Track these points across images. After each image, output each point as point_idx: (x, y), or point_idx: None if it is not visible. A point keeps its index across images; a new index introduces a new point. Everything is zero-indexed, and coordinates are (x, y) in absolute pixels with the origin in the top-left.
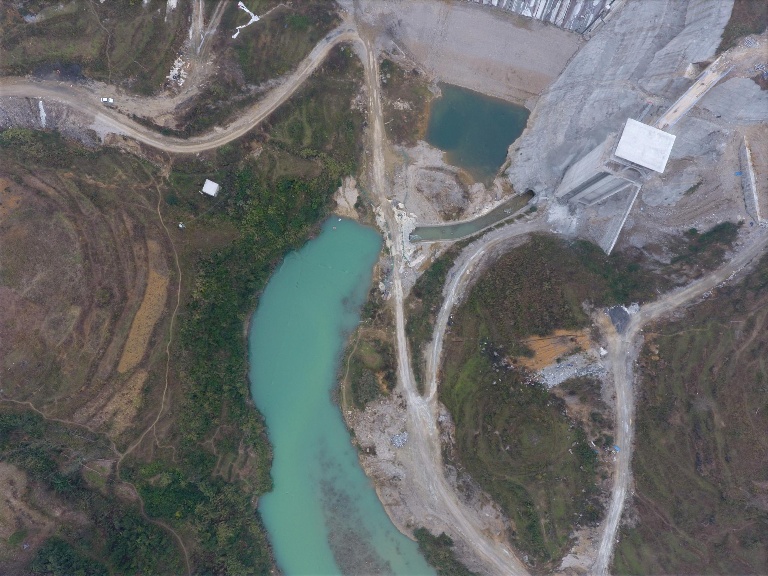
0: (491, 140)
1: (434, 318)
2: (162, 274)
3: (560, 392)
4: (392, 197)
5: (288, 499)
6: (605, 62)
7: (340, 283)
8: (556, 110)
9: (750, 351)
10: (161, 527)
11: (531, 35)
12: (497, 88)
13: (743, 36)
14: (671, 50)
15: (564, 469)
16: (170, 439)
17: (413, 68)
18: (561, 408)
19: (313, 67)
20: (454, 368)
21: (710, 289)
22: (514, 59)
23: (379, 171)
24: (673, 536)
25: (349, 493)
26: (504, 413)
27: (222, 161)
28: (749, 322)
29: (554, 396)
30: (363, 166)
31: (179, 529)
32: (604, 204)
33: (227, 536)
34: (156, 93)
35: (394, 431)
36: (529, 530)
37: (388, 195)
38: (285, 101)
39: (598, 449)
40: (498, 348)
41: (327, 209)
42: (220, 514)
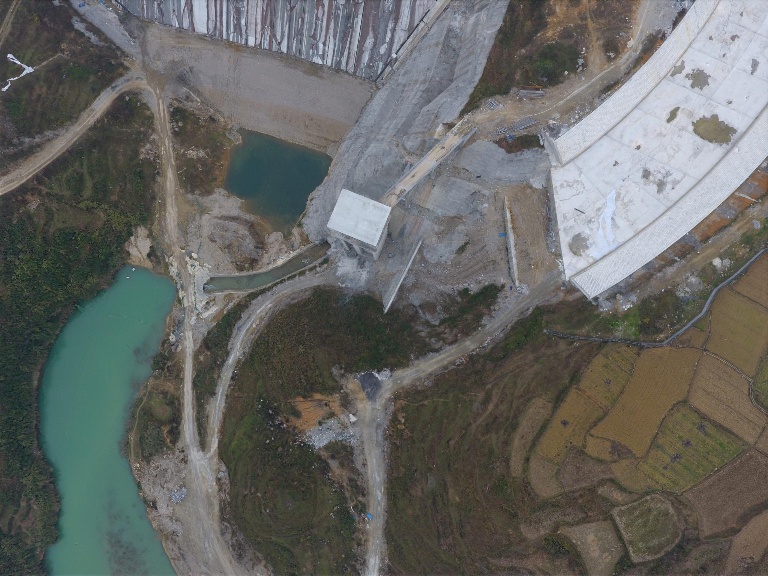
0: (293, 187)
1: (218, 372)
2: None
3: (325, 454)
4: (186, 247)
5: (77, 550)
6: (384, 114)
7: (133, 333)
8: (342, 161)
9: (485, 425)
10: None
11: (322, 83)
12: (297, 135)
13: (487, 97)
14: (430, 107)
15: (328, 532)
16: None
17: (210, 115)
18: (325, 471)
19: (95, 117)
20: (233, 424)
21: (464, 355)
22: (309, 106)
23: (172, 220)
24: None
25: (136, 546)
26: (266, 475)
27: None
28: (487, 394)
29: (320, 458)
30: (156, 215)
31: None
32: (393, 257)
33: None
34: None
35: (173, 487)
36: None
37: (181, 245)
38: (63, 153)
39: (355, 515)
40: (272, 406)
41: (118, 259)
42: None
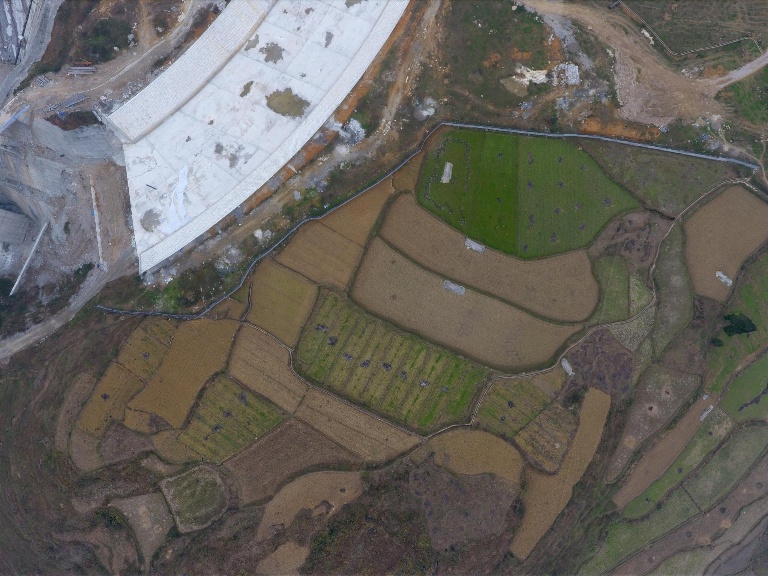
0: None
1: None
2: None
3: None
4: None
5: None
6: (3, 96)
7: None
8: None
9: (41, 401)
10: None
11: None
12: None
13: (38, 75)
14: None
15: None
16: None
17: None
18: None
19: None
20: None
21: (49, 334)
22: None
23: None
24: None
25: None
26: None
27: None
28: None
29: None
30: None
31: None
32: None
33: None
34: None
35: None
36: None
37: None
38: None
39: None
40: None
41: None
42: None
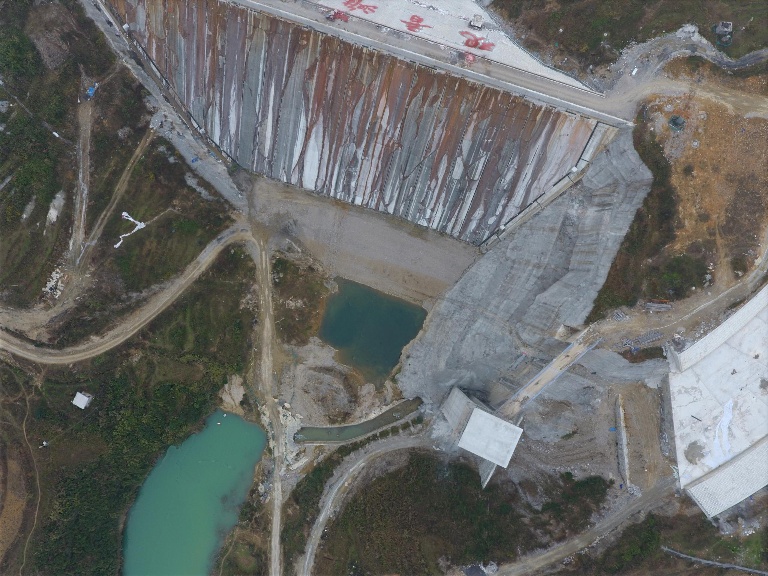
0: (387, 338)
1: (308, 530)
2: (19, 496)
3: None
4: (279, 396)
5: None
6: (492, 289)
7: (221, 480)
8: (444, 328)
9: None
10: None
11: (426, 245)
12: (394, 288)
13: (613, 308)
14: (548, 301)
15: None
16: None
17: (309, 265)
18: None
19: (201, 270)
20: None
21: (572, 554)
22: (410, 264)
23: (267, 369)
24: None
25: None
26: None
27: (96, 371)
28: None
29: None
30: (251, 363)
31: None
32: None
33: None
34: (31, 306)
35: None
36: None
37: (275, 394)
38: (168, 307)
39: None
40: (365, 575)
41: (211, 406)
42: None
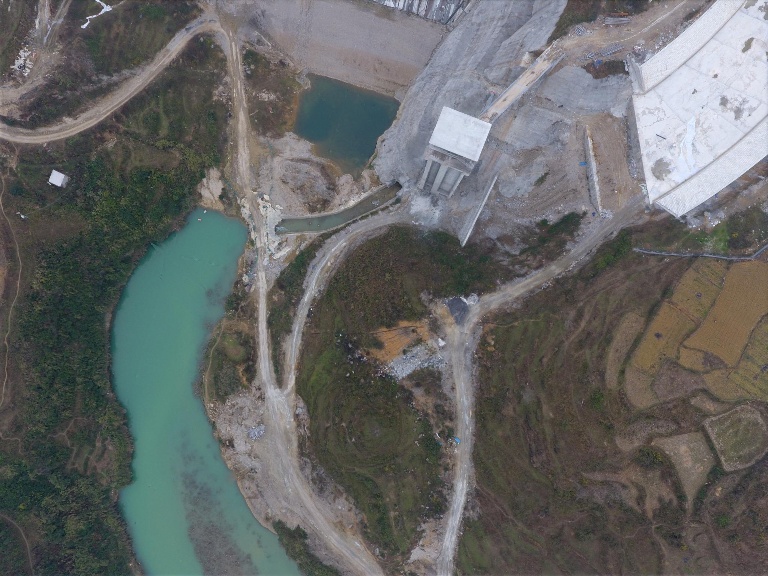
0: (361, 132)
1: (294, 310)
2: None
3: (408, 384)
4: (258, 189)
5: (150, 492)
6: (460, 52)
7: (205, 275)
8: (416, 101)
9: (578, 341)
10: (2, 519)
11: (394, 25)
12: (366, 79)
13: (574, 24)
14: (513, 39)
15: (412, 461)
16: (13, 431)
17: (280, 59)
18: (409, 400)
19: (171, 58)
20: (311, 360)
21: (550, 280)
22: (380, 50)
23: (244, 163)
24: (512, 528)
25: (211, 486)
26: (351, 405)
27: (71, 152)
28: (578, 312)
29: (403, 388)
30: (228, 157)
31: (22, 521)
32: (466, 195)
33: (77, 529)
34: None
35: (251, 423)
36: (379, 523)
37: (253, 187)
38: (140, 92)
39: (442, 441)
40: (352, 340)
41: (190, 201)
42: (71, 507)
